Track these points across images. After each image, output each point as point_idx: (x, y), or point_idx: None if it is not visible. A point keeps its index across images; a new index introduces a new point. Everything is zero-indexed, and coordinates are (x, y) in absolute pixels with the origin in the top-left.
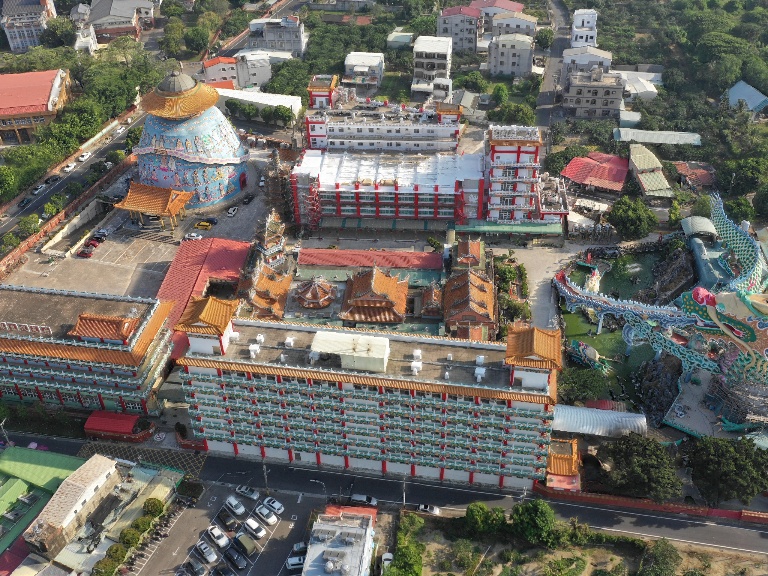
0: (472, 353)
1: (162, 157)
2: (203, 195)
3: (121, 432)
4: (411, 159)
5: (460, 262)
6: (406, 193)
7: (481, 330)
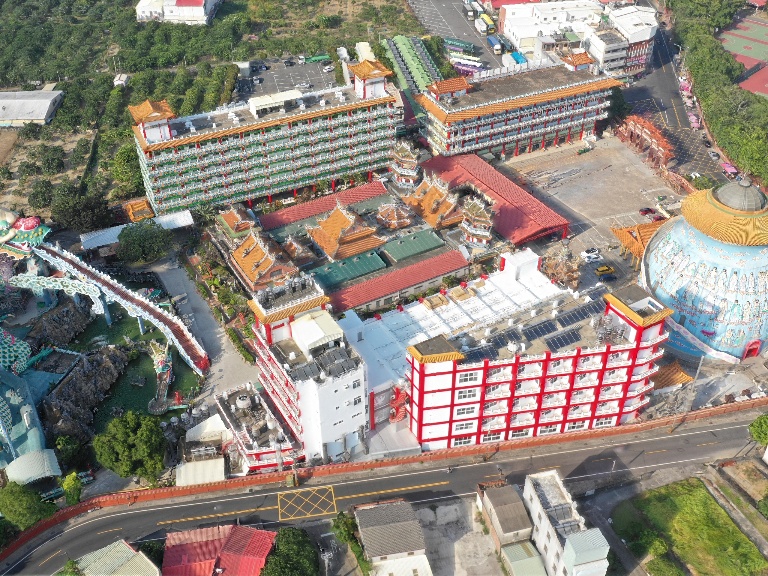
0: None
1: None
2: None
3: None
4: None
5: None
6: None
7: None
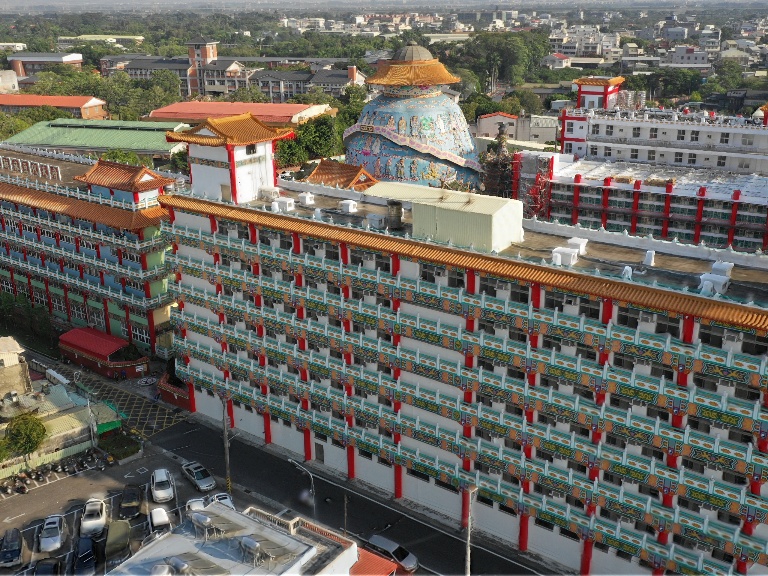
0: (707, 266)
1: (368, 138)
2: None
3: (95, 353)
4: (706, 172)
5: None
6: (683, 199)
7: None
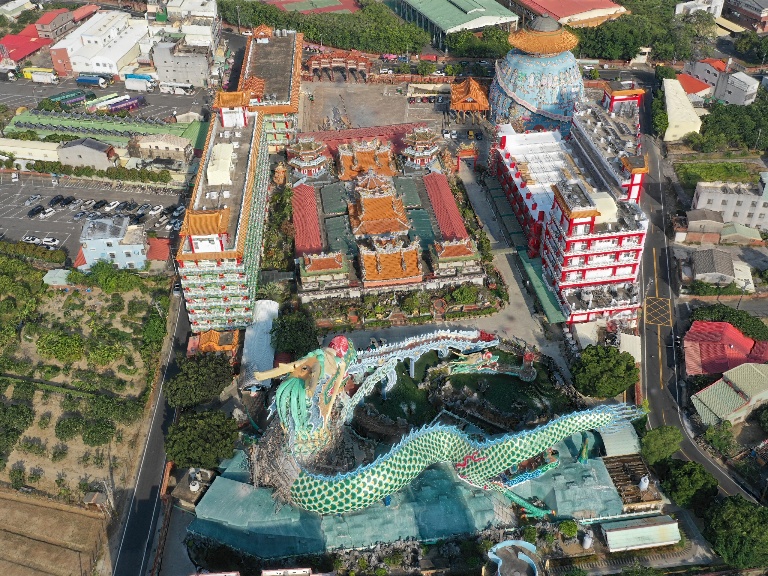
0: (233, 218)
1: None
2: None
3: None
4: None
5: (435, 245)
6: None
7: (338, 266)
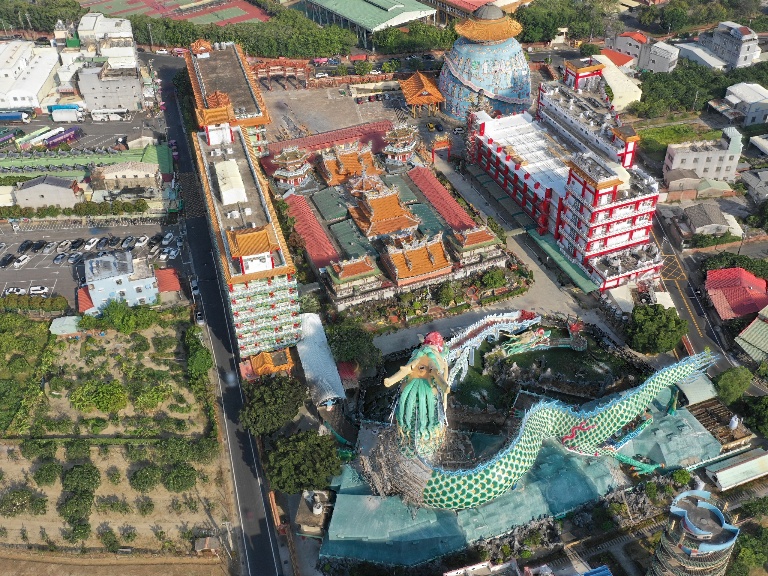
0: None
1: None
2: (455, 108)
3: None
4: None
5: (455, 235)
6: None
7: (370, 269)
